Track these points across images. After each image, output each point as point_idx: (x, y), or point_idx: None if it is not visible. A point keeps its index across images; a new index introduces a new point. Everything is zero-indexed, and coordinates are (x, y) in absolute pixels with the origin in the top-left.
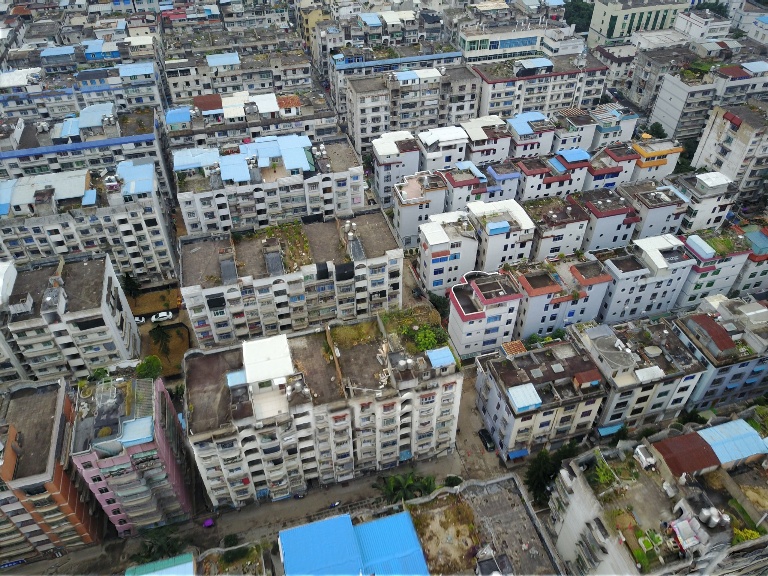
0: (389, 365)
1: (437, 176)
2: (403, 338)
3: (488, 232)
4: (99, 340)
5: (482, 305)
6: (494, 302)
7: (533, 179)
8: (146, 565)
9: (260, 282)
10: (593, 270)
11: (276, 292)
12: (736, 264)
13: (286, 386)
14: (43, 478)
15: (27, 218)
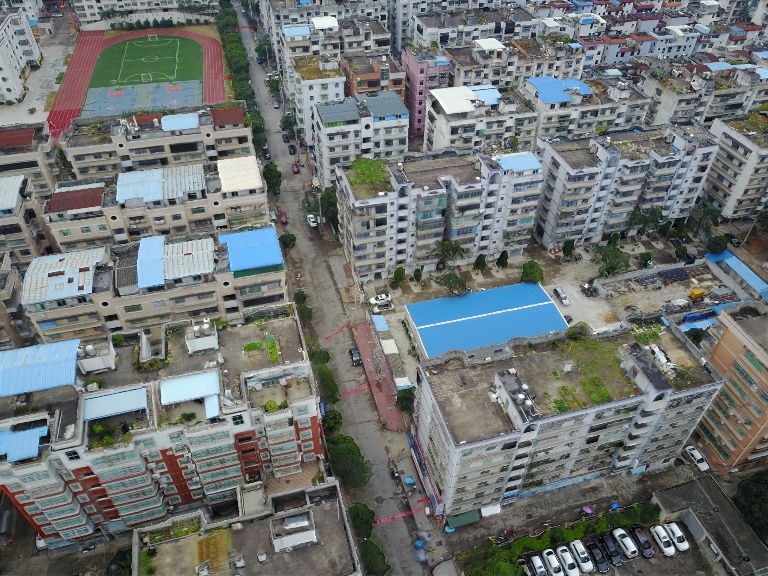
0: (550, 48)
1: (543, 3)
2: (554, 41)
3: (581, 22)
4: None
5: (584, 47)
6: (591, 44)
7: (600, 8)
8: (471, 85)
9: (468, 28)
10: (643, 36)
11: (473, 37)
12: (722, 41)
13: (503, 51)
14: (402, 76)
15: (321, 6)
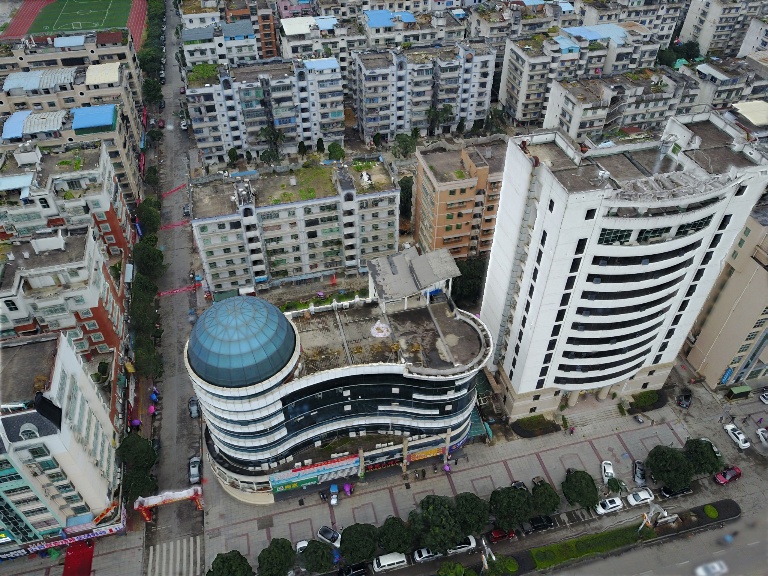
0: None
1: None
2: None
3: None
4: (269, 1)
5: None
6: None
7: None
8: None
9: None
10: None
11: None
12: None
13: None
14: (269, 12)
15: None
